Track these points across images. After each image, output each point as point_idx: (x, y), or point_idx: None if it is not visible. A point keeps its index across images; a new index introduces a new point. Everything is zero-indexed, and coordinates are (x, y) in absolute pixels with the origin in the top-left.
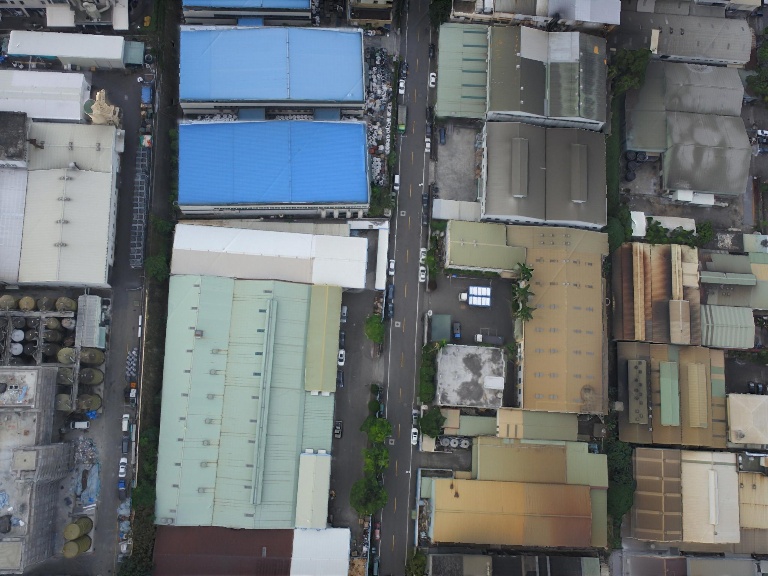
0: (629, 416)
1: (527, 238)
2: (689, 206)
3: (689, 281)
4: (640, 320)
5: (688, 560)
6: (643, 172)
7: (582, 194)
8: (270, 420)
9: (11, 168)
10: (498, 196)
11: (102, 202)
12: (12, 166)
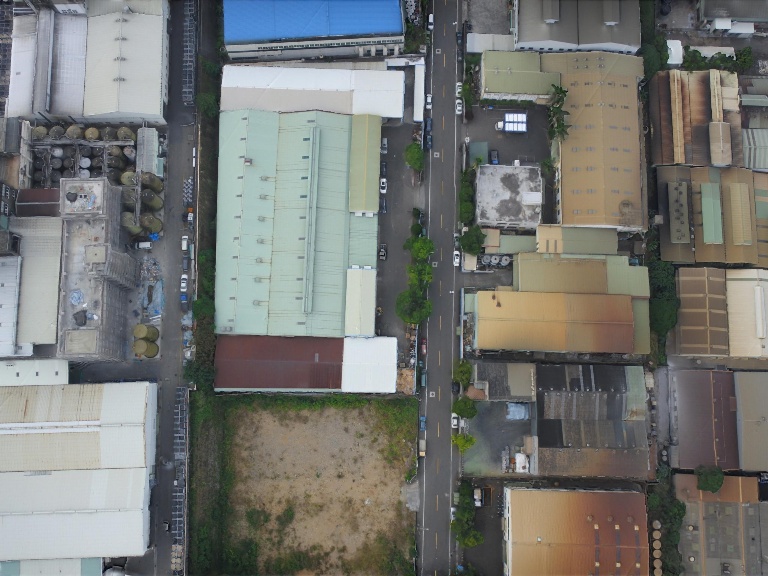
0: (670, 236)
1: (561, 64)
2: (728, 38)
3: (729, 105)
4: (679, 144)
5: (735, 373)
6: (679, 7)
7: (614, 15)
8: (317, 238)
9: (72, 15)
10: (530, 24)
11: (155, 42)
12: (73, 13)
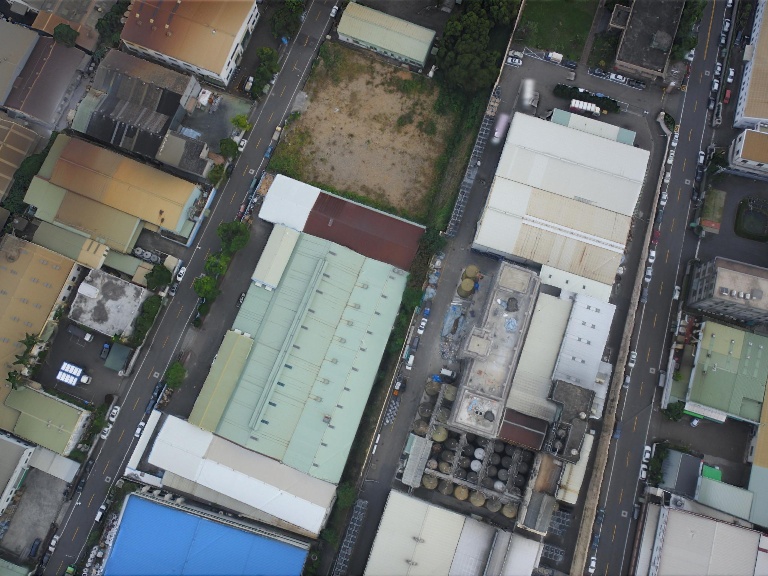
0: None
1: None
2: None
3: None
4: None
5: (2, 103)
6: None
7: None
8: (291, 324)
9: None
10: (5, 463)
11: (373, 573)
12: None
